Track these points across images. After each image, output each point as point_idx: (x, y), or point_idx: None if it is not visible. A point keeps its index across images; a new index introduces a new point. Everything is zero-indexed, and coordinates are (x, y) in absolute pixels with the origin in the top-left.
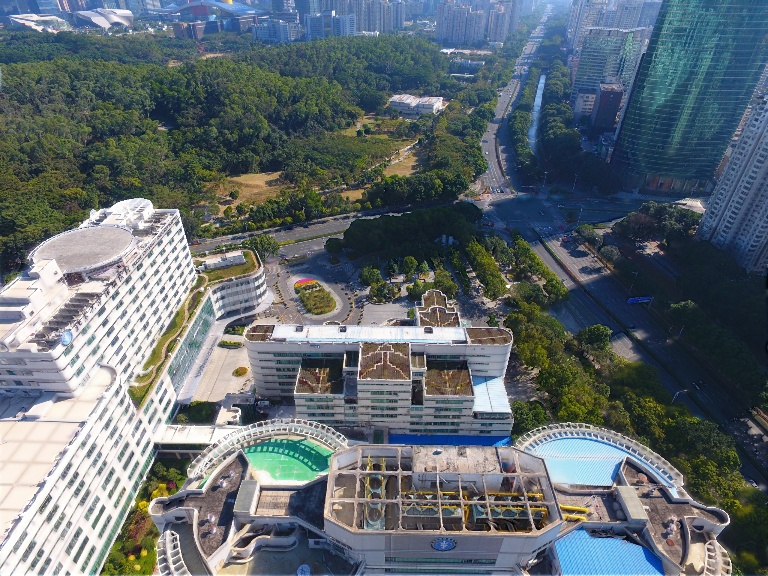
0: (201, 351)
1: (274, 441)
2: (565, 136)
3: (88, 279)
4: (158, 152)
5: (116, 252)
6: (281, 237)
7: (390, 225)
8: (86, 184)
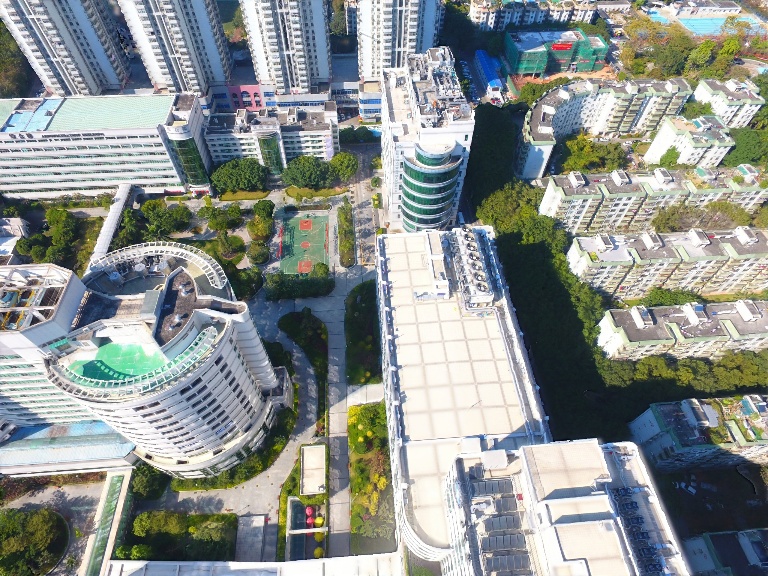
0: None
1: None
2: None
3: None
4: None
5: None
6: None
7: None
8: None
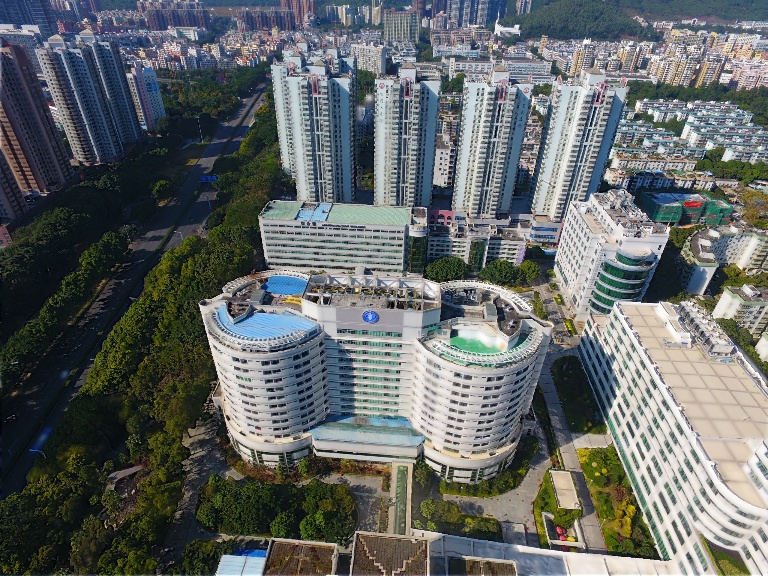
0: None
1: (492, 365)
2: None
3: None
4: None
5: None
6: None
7: None
8: None
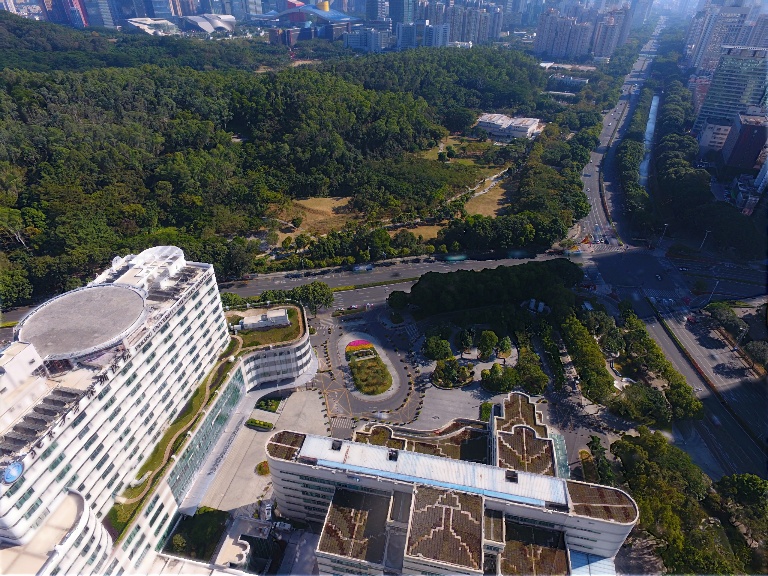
0: (222, 435)
1: None
2: (691, 178)
3: (77, 365)
4: (225, 169)
5: (117, 331)
6: (340, 280)
7: (468, 284)
8: (147, 201)
